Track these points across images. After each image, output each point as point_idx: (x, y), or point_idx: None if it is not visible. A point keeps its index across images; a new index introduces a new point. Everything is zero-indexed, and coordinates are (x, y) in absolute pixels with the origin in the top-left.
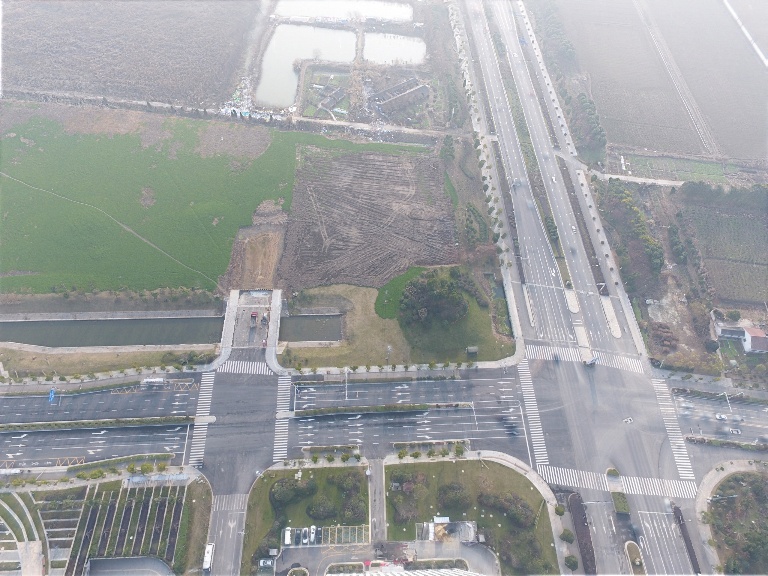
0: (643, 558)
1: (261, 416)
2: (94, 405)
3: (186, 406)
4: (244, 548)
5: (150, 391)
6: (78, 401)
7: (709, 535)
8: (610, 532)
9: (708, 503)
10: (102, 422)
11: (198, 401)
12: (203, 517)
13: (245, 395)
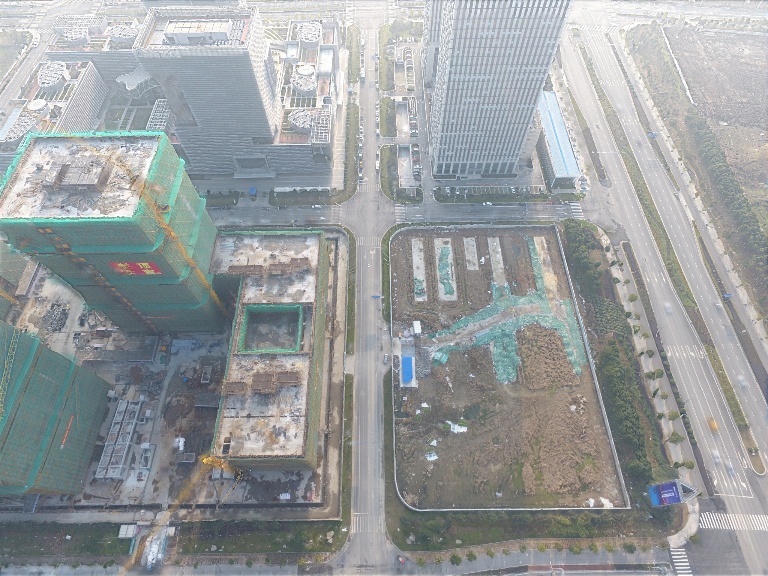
0: (586, 47)
1: (380, 7)
2: (293, 4)
3: (340, 4)
4: (379, 43)
5: (320, 0)
6: (284, 3)
7: (623, 41)
8: (569, 40)
9: (625, 32)
10: (299, 8)
11: (346, 3)
12: (357, 35)
13: (371, 1)
